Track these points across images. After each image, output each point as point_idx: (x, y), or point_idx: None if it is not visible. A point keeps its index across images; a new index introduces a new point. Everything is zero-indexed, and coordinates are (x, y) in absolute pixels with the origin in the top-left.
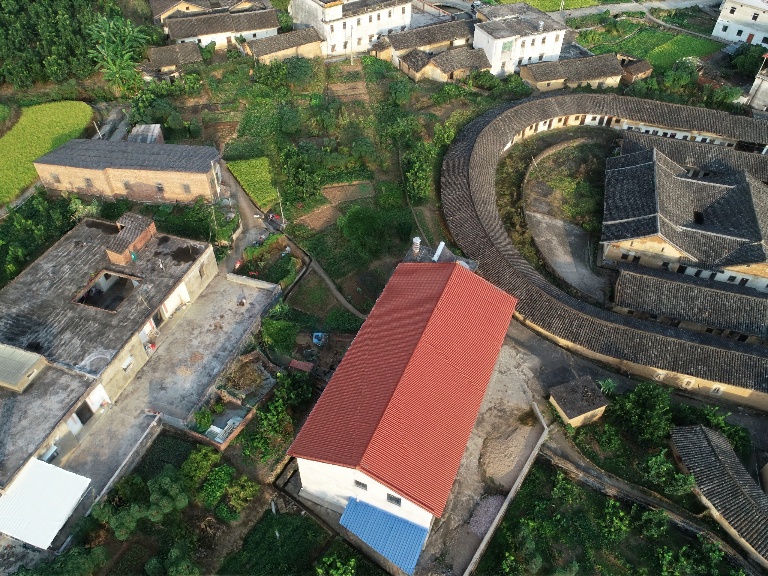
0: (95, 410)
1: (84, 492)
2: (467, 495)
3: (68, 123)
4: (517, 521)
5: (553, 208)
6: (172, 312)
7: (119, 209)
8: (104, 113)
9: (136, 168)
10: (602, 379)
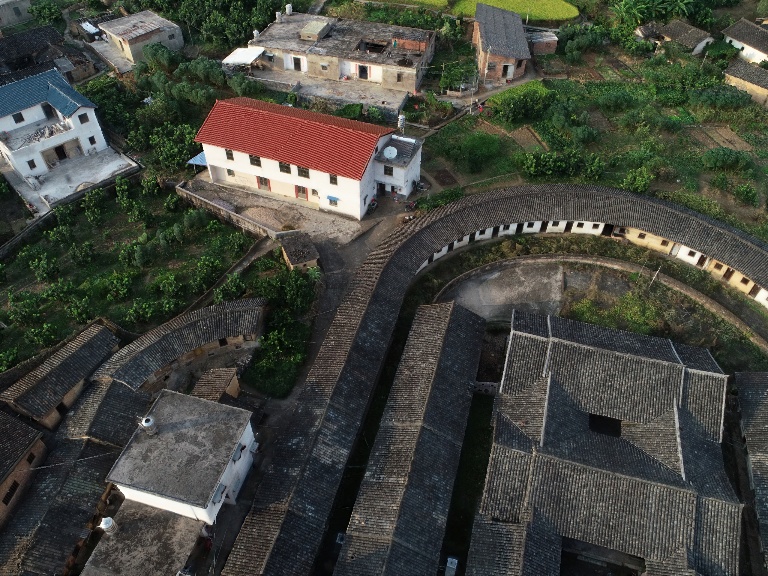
0: (303, 71)
1: (246, 64)
2: (238, 199)
3: (547, 14)
4: (224, 231)
5: (578, 290)
6: (374, 81)
7: (464, 50)
8: (576, 26)
9: (482, 30)
10: (336, 292)
